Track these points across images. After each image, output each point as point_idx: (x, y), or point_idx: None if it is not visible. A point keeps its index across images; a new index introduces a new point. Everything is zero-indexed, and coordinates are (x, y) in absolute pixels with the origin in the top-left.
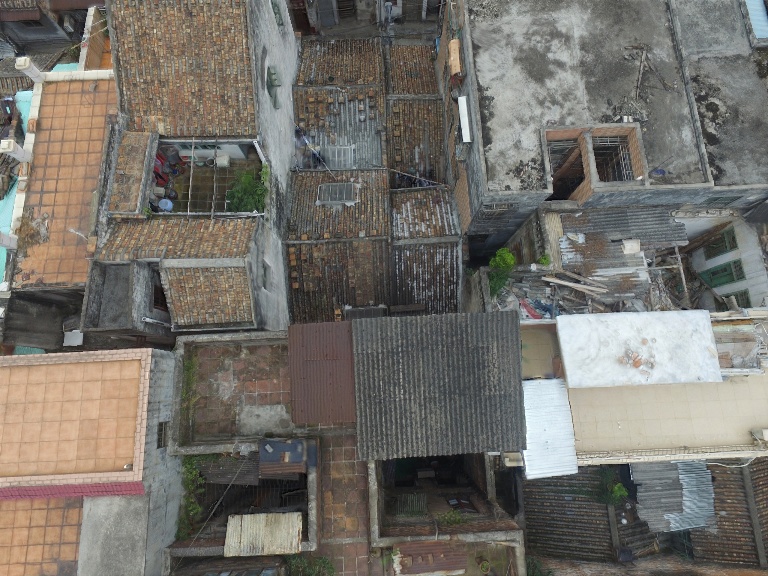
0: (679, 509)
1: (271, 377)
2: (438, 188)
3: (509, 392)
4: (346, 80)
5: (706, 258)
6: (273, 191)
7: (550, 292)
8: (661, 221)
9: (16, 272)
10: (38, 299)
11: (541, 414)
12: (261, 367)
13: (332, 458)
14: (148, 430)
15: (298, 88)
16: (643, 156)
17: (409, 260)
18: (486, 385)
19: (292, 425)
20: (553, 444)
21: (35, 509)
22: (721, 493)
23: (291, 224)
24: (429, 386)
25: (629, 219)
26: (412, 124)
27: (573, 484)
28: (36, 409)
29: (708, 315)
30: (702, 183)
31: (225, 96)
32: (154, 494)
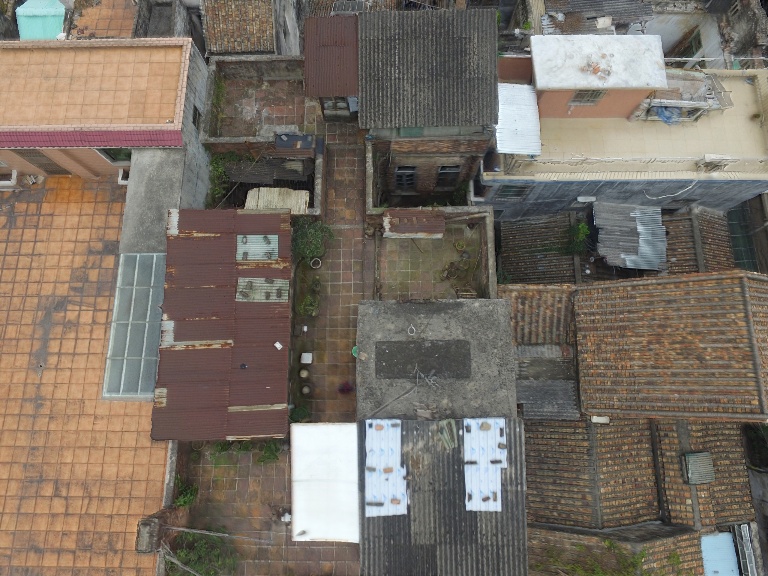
0: (635, 252)
1: (287, 104)
2: None
3: (486, 76)
4: None
5: None
6: None
7: None
8: (631, 2)
9: (72, 27)
10: None
11: (513, 109)
12: (279, 96)
13: (336, 165)
14: (187, 98)
15: None
16: None
17: None
18: (467, 69)
19: None
20: (522, 132)
21: (85, 202)
22: (673, 244)
23: None
24: (420, 69)
25: (604, 1)
26: None
27: (545, 244)
28: (95, 81)
29: (659, 39)
30: None
31: None
32: (189, 155)
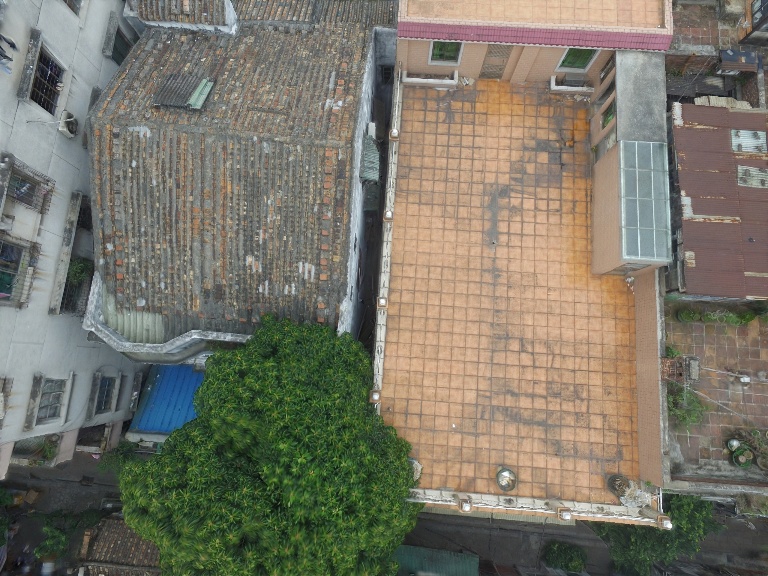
0: None
1: (702, 26)
2: None
3: None
4: None
5: None
6: None
7: None
8: None
9: None
10: None
11: None
12: (693, 19)
13: None
14: None
15: None
16: None
17: None
18: None
19: None
20: None
21: (515, 104)
22: None
23: None
24: None
25: None
26: None
27: None
28: None
29: None
30: None
31: None
32: None
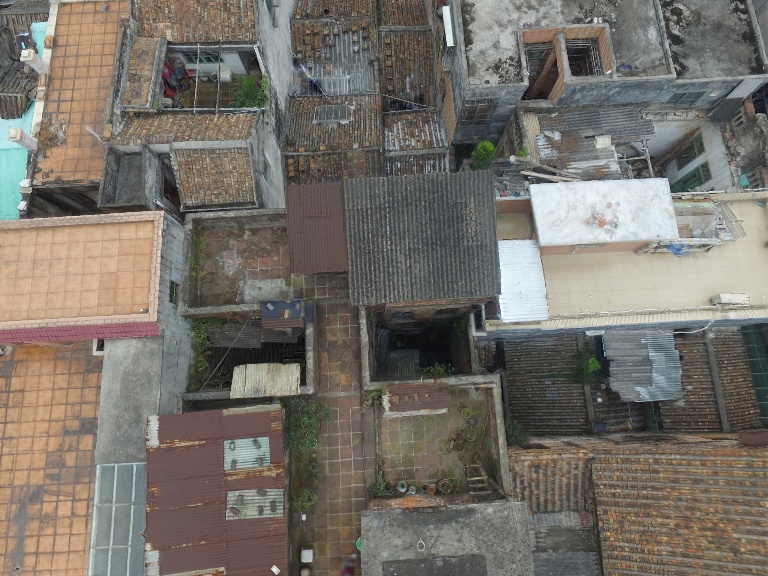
0: (649, 383)
1: (272, 255)
2: (427, 111)
3: (485, 243)
4: (340, 13)
5: (678, 169)
6: (272, 101)
7: (528, 185)
8: (630, 118)
9: (37, 171)
10: (56, 201)
11: (515, 269)
12: (262, 246)
13: (328, 323)
14: (161, 280)
15: (295, 20)
16: (611, 52)
17: (400, 171)
18: (464, 237)
19: (291, 296)
20: (526, 295)
21: (58, 374)
22: (688, 370)
23: (289, 139)
24: (413, 238)
25: (601, 117)
26: (403, 55)
27: (552, 369)
28: (61, 264)
29: (667, 182)
30: (665, 75)
31: (227, 3)
32: (167, 340)
